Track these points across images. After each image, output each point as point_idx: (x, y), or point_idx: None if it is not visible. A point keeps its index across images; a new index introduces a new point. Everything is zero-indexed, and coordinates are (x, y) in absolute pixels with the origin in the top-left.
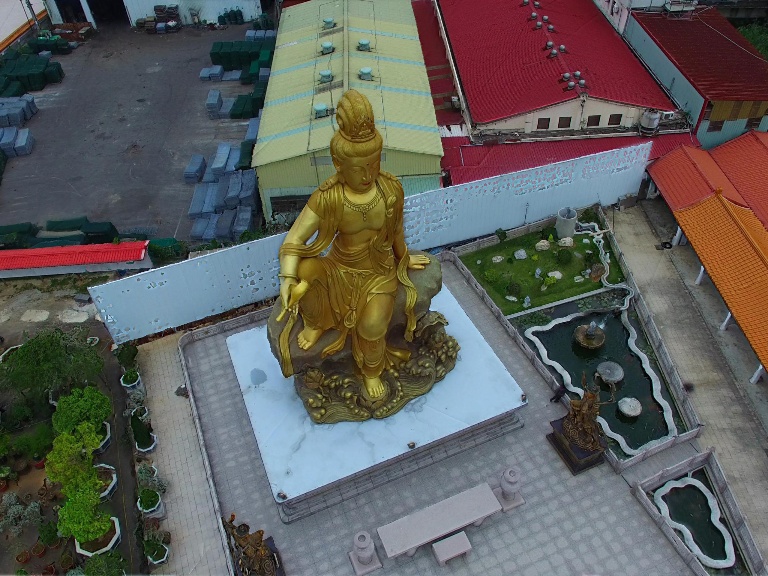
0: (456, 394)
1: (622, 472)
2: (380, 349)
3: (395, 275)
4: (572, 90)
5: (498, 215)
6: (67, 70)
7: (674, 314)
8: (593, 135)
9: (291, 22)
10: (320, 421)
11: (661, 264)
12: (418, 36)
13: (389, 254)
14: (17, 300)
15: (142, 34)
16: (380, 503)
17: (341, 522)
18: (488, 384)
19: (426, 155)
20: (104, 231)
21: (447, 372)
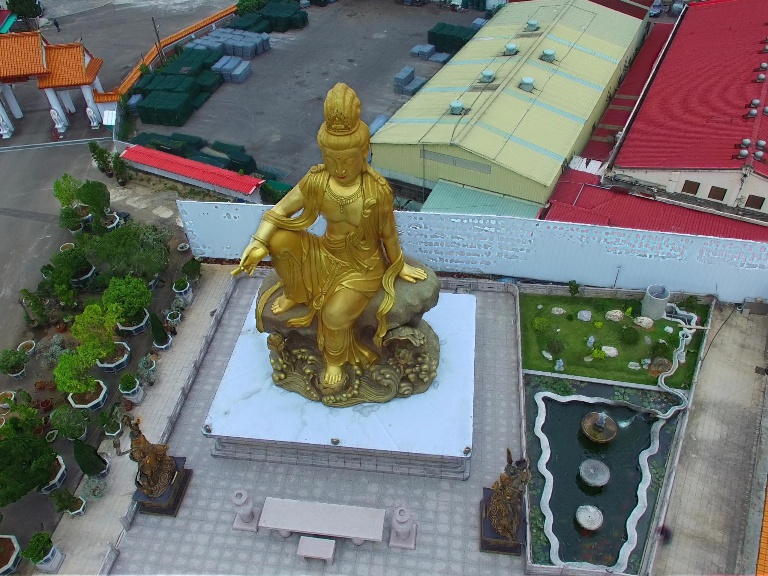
0: (409, 416)
1: (531, 575)
2: (340, 340)
3: (378, 277)
4: (741, 159)
5: (584, 267)
6: (313, 20)
7: (720, 449)
8: (746, 218)
9: (503, 17)
10: (278, 383)
11: (748, 389)
12: (620, 59)
13: (374, 255)
14: (160, 195)
15: (391, 2)
16: (293, 479)
17: (253, 477)
18: (444, 422)
19: (531, 180)
20: (243, 162)
21: (415, 393)
